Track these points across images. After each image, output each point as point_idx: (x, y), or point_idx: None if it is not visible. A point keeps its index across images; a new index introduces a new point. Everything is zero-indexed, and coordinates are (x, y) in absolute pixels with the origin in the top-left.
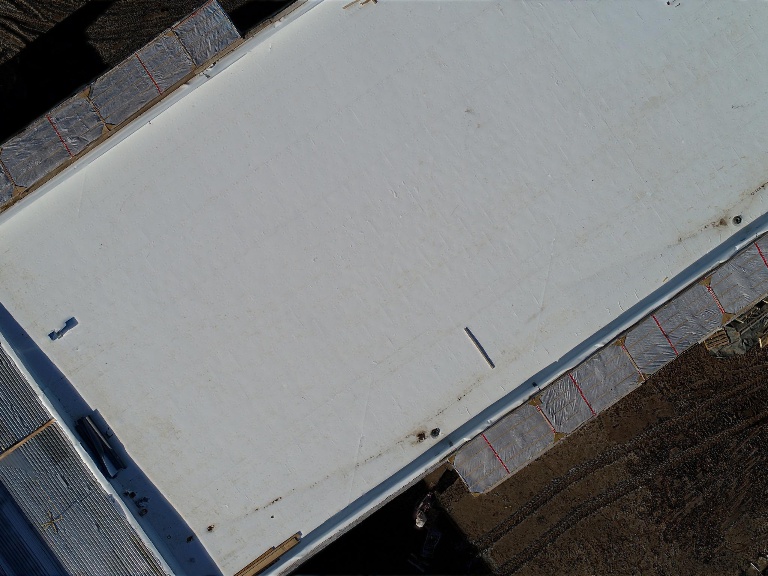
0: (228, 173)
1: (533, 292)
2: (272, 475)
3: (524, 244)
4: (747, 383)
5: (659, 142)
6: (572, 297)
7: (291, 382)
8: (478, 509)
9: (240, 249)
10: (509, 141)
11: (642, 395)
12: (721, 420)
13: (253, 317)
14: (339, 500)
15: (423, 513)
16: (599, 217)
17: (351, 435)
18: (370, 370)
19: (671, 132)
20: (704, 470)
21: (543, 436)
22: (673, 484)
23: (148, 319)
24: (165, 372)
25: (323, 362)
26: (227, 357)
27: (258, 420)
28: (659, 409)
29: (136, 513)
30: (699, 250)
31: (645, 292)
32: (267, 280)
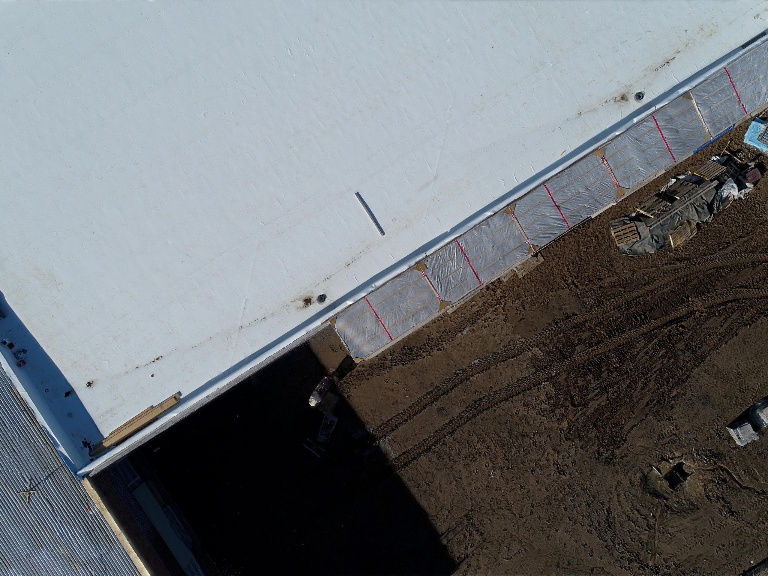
0: (119, 21)
1: (427, 159)
2: (154, 333)
3: (420, 110)
4: (657, 283)
5: (562, 11)
6: (467, 166)
7: (176, 239)
8: (377, 397)
9: (129, 100)
10: (408, 2)
11: (549, 290)
12: (629, 319)
13: (140, 170)
14: (221, 362)
15: (317, 393)
16: (498, 86)
17: (236, 296)
18: (257, 231)
19: (575, 2)
20: (609, 370)
21: (428, 303)
22: (577, 382)
23: (33, 167)
24: (48, 222)
25: (210, 220)
26: (112, 210)
27: (141, 276)
28: (566, 305)
29: (13, 363)
30: (599, 125)
31: (541, 165)
32: (155, 133)
